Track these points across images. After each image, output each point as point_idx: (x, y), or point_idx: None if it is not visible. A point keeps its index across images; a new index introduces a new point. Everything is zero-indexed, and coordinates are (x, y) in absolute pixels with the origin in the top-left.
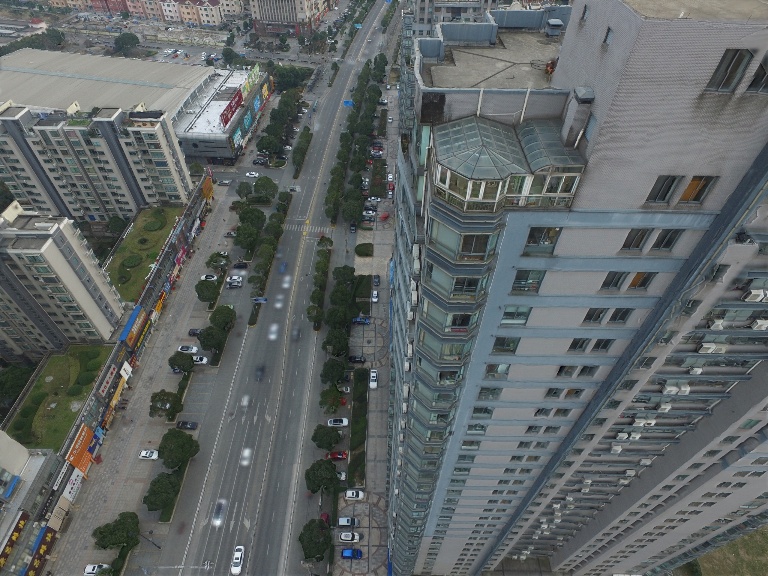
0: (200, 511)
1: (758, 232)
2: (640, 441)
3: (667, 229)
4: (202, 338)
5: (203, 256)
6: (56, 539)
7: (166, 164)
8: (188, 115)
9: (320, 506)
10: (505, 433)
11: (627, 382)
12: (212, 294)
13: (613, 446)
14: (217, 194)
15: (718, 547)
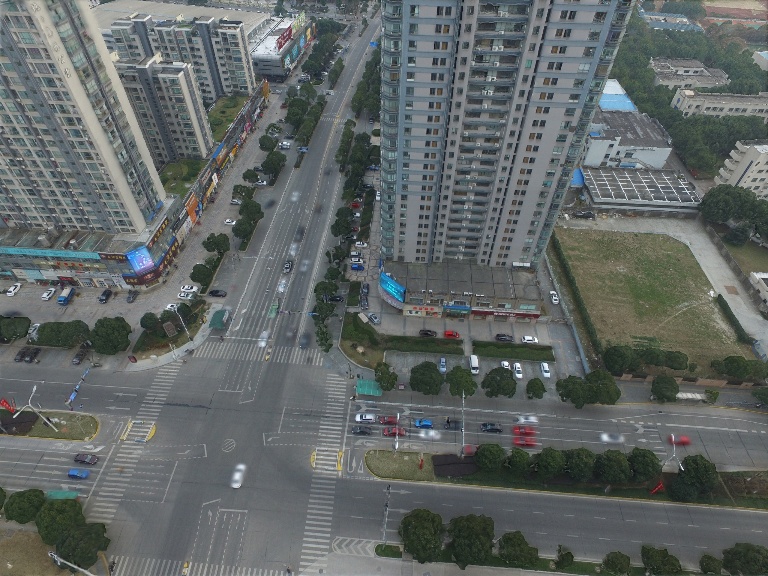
0: (264, 248)
1: None
2: (493, 96)
3: None
4: (265, 164)
5: (262, 132)
6: (177, 253)
7: (241, 60)
8: (251, 44)
9: None
10: (424, 65)
11: (468, 26)
12: (270, 145)
13: (483, 104)
14: (271, 99)
15: None
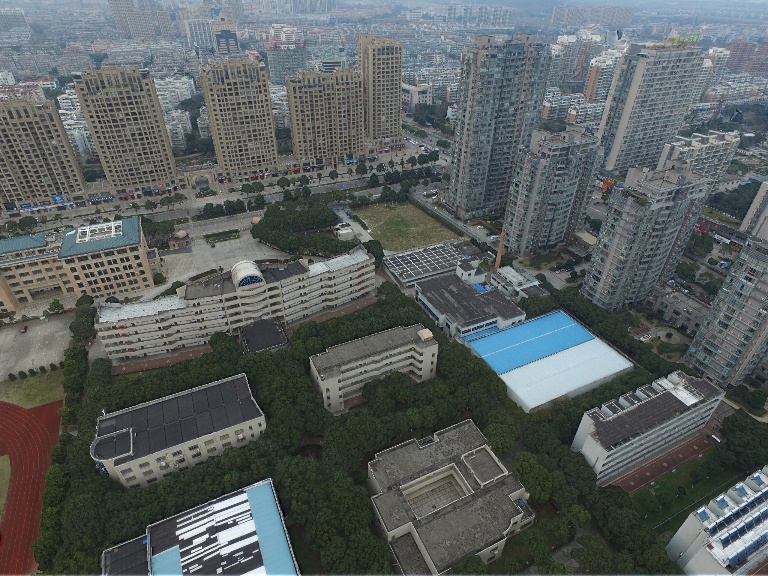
0: None
1: None
2: None
3: None
4: None
5: None
6: None
7: (752, 202)
8: None
9: None
10: None
11: None
12: None
13: None
14: None
15: None
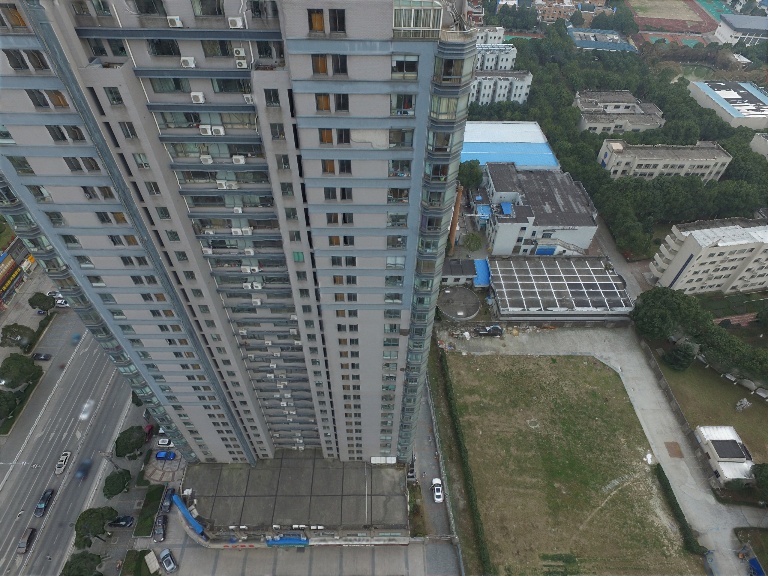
0: (38, 426)
1: (148, 68)
2: (263, 290)
3: (27, 50)
4: None
5: None
6: None
7: None
8: None
9: (145, 418)
10: (110, 266)
11: (161, 210)
12: None
13: (252, 299)
14: None
15: (413, 411)
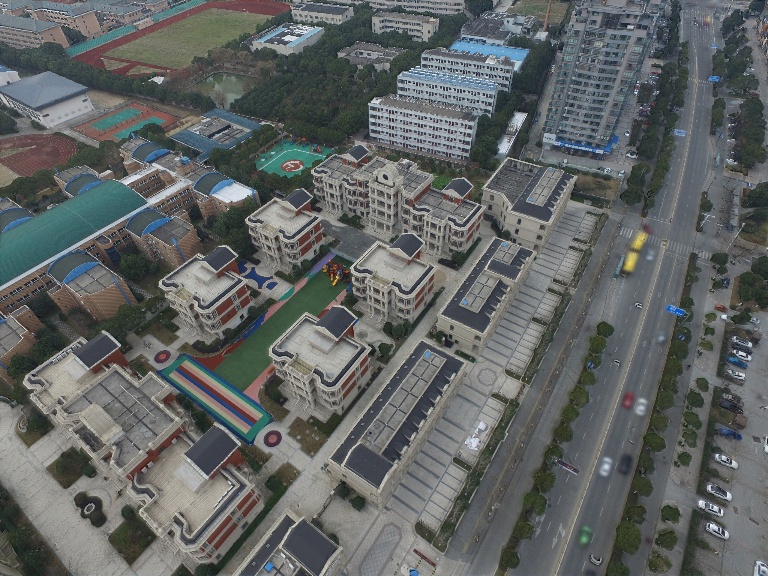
0: None
1: None
2: None
3: None
4: None
5: (760, 78)
6: None
7: None
8: None
9: None
10: None
11: None
12: None
13: None
14: None
15: None
